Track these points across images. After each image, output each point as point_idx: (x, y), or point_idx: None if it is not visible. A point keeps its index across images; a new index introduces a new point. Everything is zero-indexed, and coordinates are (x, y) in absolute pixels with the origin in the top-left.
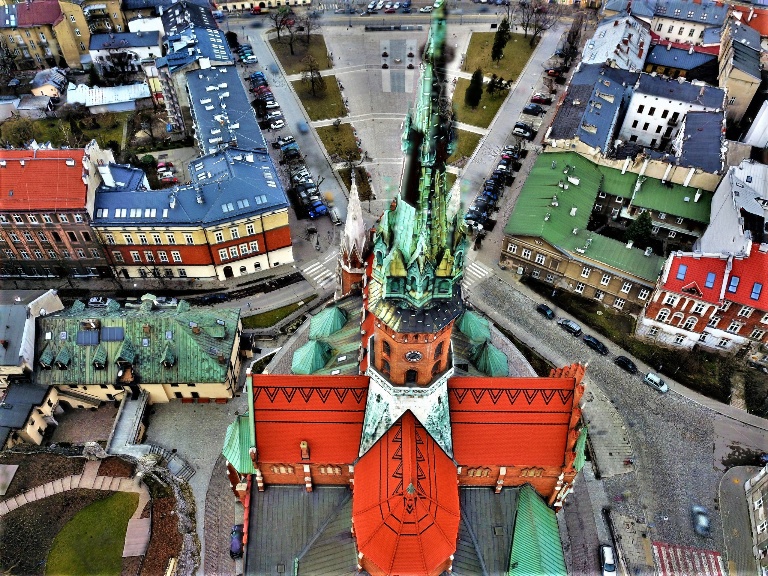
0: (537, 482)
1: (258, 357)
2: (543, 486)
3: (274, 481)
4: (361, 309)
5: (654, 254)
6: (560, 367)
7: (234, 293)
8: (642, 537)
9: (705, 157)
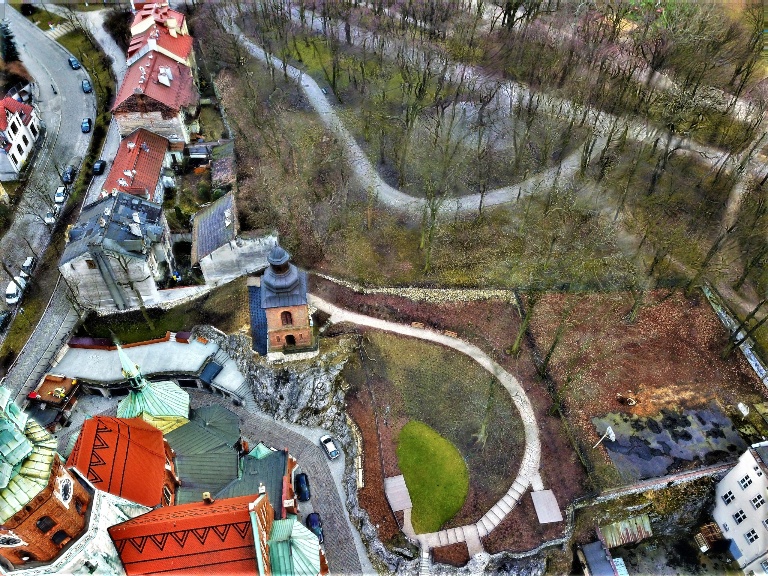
0: None
1: None
2: None
3: None
4: None
5: None
6: None
7: None
8: None
9: None
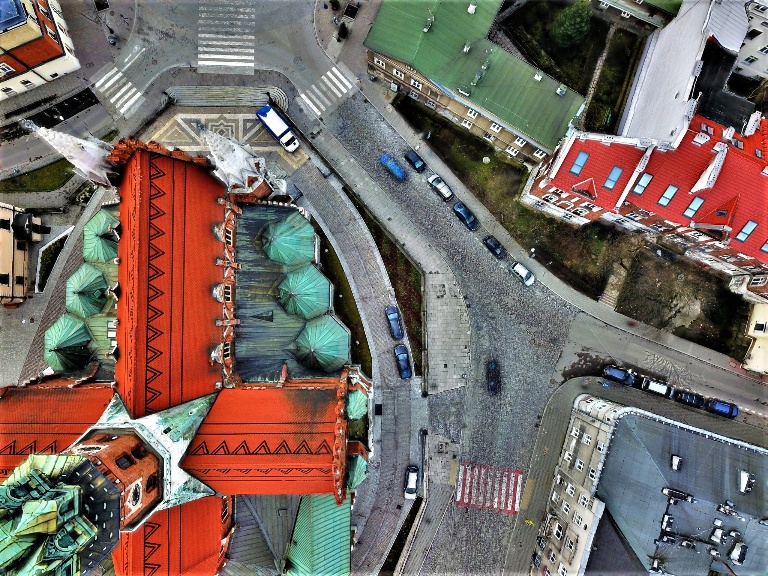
0: None
1: (47, 240)
2: None
3: None
4: None
5: (571, 89)
6: (416, 249)
7: (4, 130)
8: (452, 458)
9: None
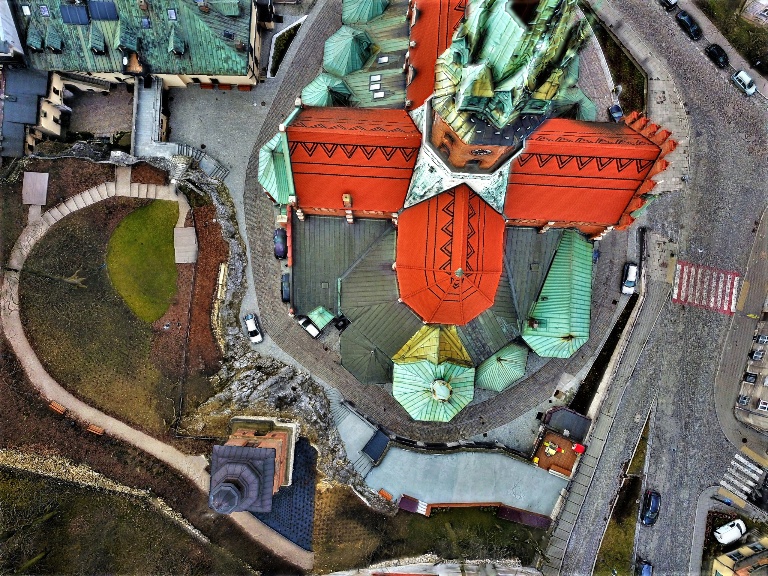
0: (583, 227)
1: (280, 28)
2: (588, 229)
3: (314, 213)
4: None
5: None
6: (637, 55)
7: None
8: (669, 256)
9: None
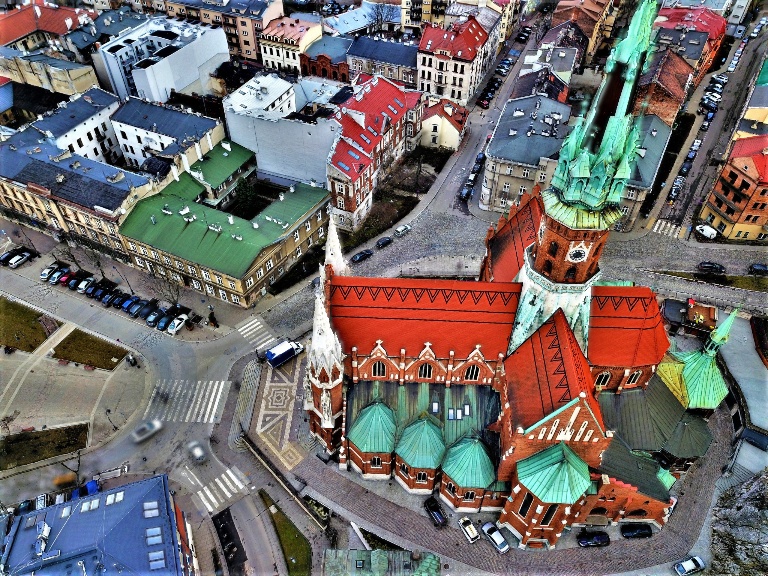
0: None
1: None
2: None
3: None
4: (403, 366)
5: None
6: None
7: None
8: None
9: (189, 125)
